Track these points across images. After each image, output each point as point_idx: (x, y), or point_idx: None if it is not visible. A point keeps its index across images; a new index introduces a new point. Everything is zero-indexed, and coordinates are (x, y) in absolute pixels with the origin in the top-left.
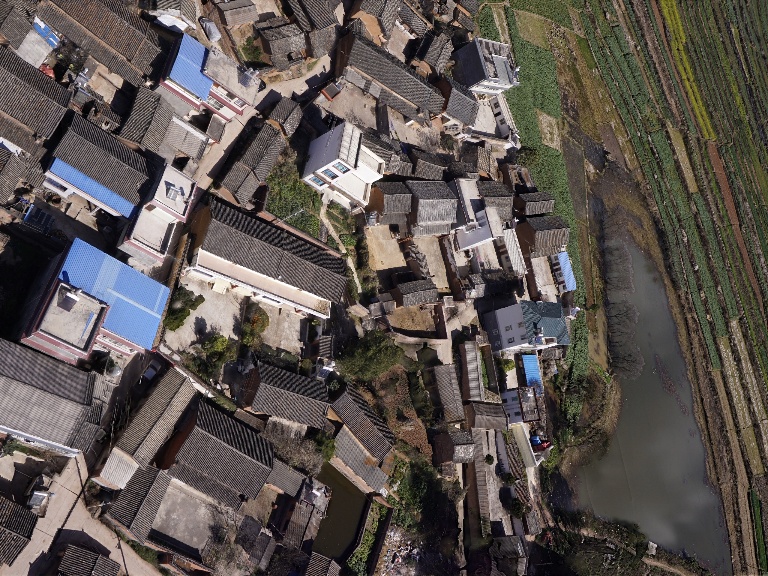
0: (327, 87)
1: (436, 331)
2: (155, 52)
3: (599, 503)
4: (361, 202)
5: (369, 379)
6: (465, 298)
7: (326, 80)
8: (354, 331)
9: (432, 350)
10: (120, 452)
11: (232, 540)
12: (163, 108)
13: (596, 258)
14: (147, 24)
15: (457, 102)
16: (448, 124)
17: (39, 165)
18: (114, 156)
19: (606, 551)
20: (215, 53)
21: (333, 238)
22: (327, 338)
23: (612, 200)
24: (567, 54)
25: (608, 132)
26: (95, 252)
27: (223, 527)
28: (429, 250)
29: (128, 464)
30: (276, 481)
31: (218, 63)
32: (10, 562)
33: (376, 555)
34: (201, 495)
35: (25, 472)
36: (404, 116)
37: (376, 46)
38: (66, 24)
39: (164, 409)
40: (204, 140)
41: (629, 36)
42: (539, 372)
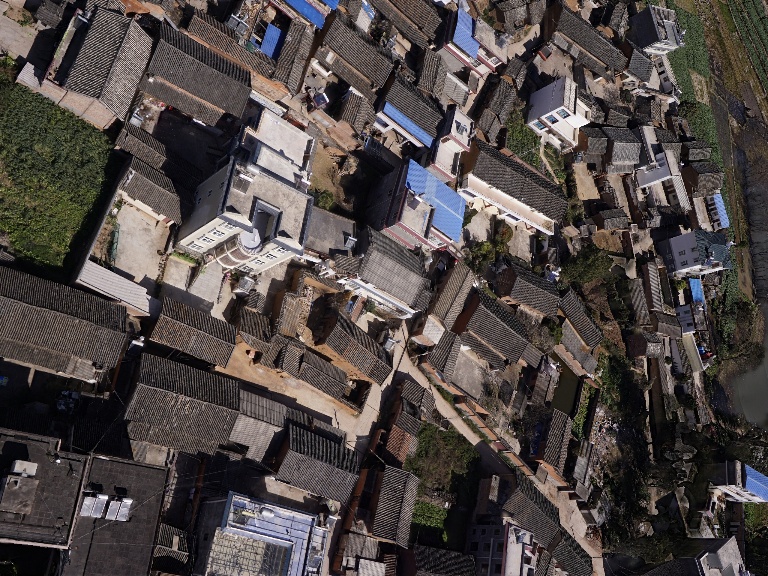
0: (542, 49)
1: (624, 253)
2: (438, 22)
3: (749, 411)
4: (572, 143)
5: (580, 286)
6: (646, 227)
7: (538, 44)
8: (567, 248)
9: (622, 268)
10: (433, 319)
11: (497, 395)
12: (442, 66)
13: (741, 203)
14: (430, 0)
15: (637, 61)
16: (626, 81)
17: (373, 107)
18: (421, 101)
19: (762, 445)
20: (480, 22)
21: (550, 172)
22: (553, 250)
23: (752, 152)
24: (711, 19)
25: (747, 90)
26: (422, 170)
27: (490, 385)
28: (615, 187)
29: (438, 327)
30: (524, 355)
31: (482, 30)
32: (380, 383)
33: (590, 423)
34: (475, 360)
35: (374, 328)
36: (593, 74)
37: (576, 14)
38: (380, 2)
39: (459, 290)
40: (467, 91)
41: (764, 1)
42: (703, 294)
